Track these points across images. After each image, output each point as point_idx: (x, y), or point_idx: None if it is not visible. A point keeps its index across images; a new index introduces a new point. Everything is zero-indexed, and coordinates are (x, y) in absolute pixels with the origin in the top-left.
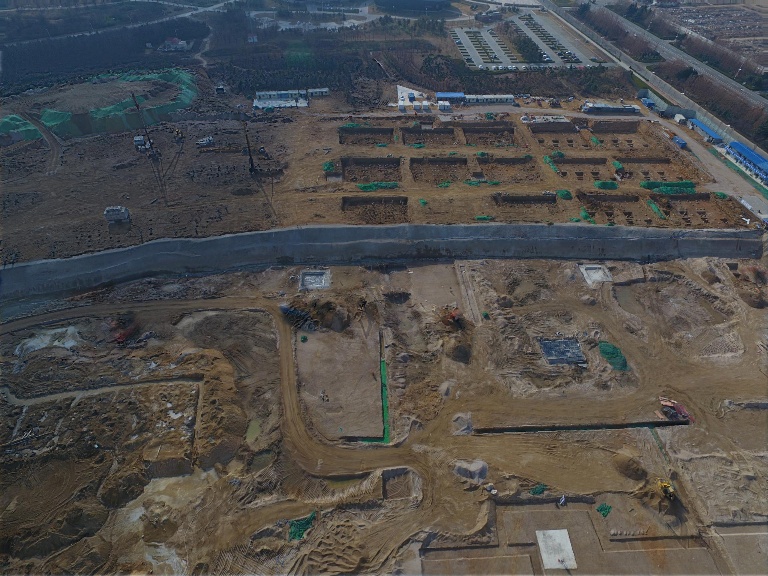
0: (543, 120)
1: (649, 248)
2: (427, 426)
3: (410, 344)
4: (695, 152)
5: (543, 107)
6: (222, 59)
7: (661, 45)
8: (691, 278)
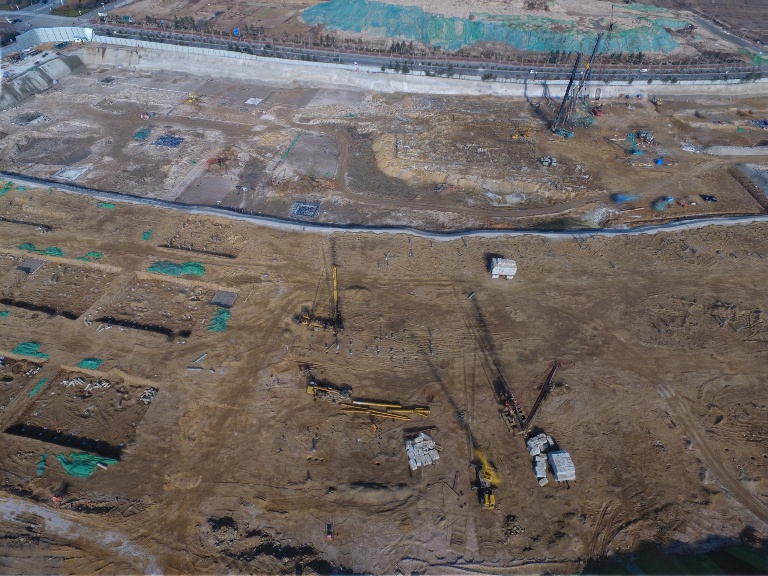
0: None
1: None
2: (278, 130)
3: (258, 165)
4: None
5: None
6: None
7: None
8: (7, 154)
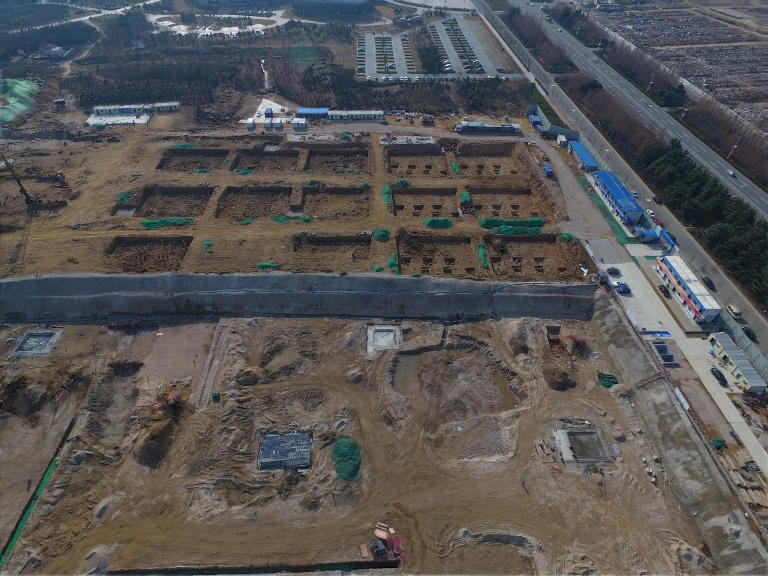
0: (405, 141)
1: (458, 305)
2: (47, 566)
3: (106, 435)
4: (561, 182)
5: (414, 125)
6: (90, 68)
7: (582, 53)
8: (494, 346)
